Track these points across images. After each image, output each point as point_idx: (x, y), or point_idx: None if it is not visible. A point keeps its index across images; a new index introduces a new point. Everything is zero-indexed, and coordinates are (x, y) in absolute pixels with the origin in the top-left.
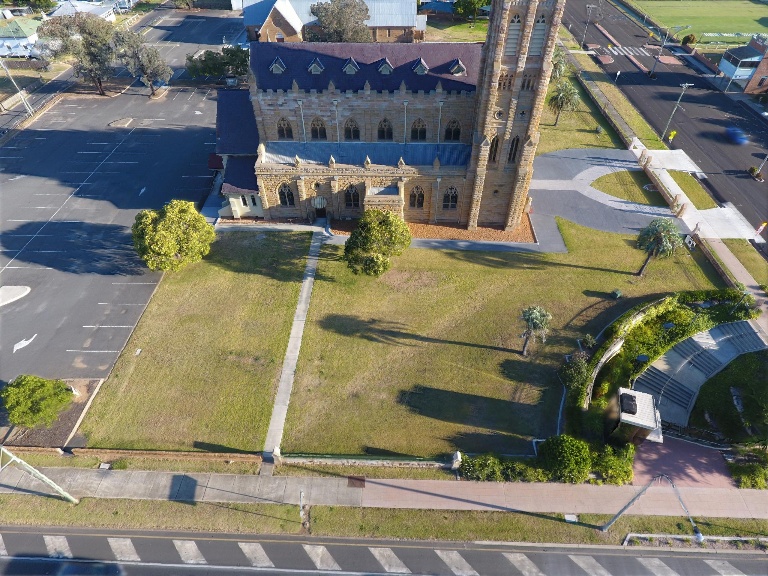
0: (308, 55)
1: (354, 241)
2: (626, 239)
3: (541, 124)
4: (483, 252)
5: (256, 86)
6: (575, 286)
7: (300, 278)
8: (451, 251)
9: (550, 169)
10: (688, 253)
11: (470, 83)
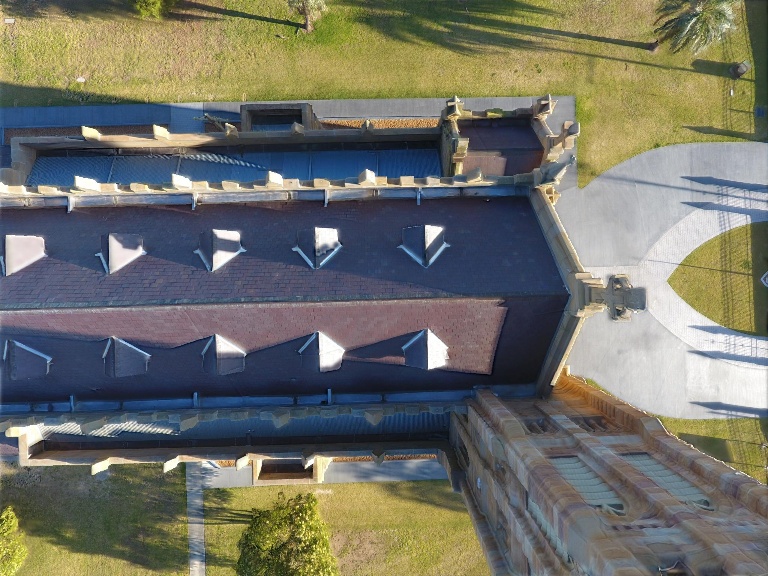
0: None
1: None
2: (685, 433)
3: (624, 41)
4: None
5: None
6: None
7: (184, 564)
8: (408, 485)
9: (607, 229)
10: (767, 463)
11: (456, 370)
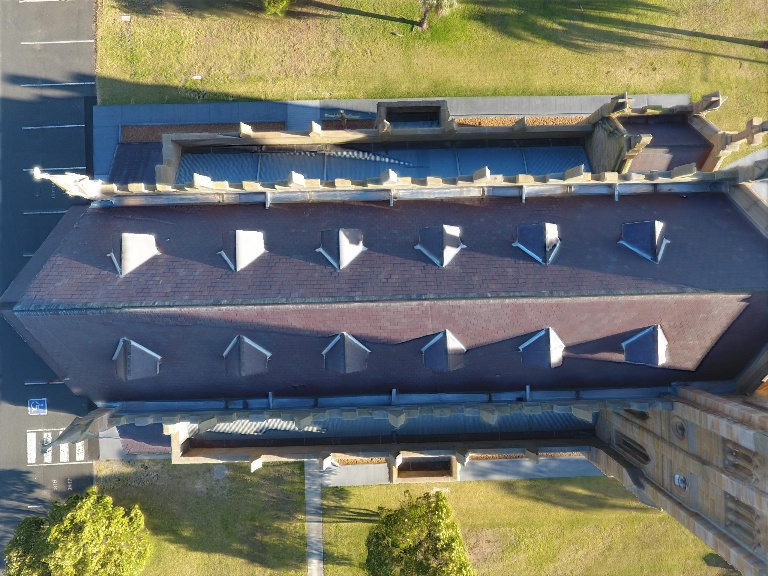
0: (213, 332)
1: (383, 575)
2: None
3: (738, 39)
4: (573, 480)
5: (102, 416)
6: (697, 546)
7: (302, 563)
8: (525, 483)
9: None
10: None
11: (663, 366)
